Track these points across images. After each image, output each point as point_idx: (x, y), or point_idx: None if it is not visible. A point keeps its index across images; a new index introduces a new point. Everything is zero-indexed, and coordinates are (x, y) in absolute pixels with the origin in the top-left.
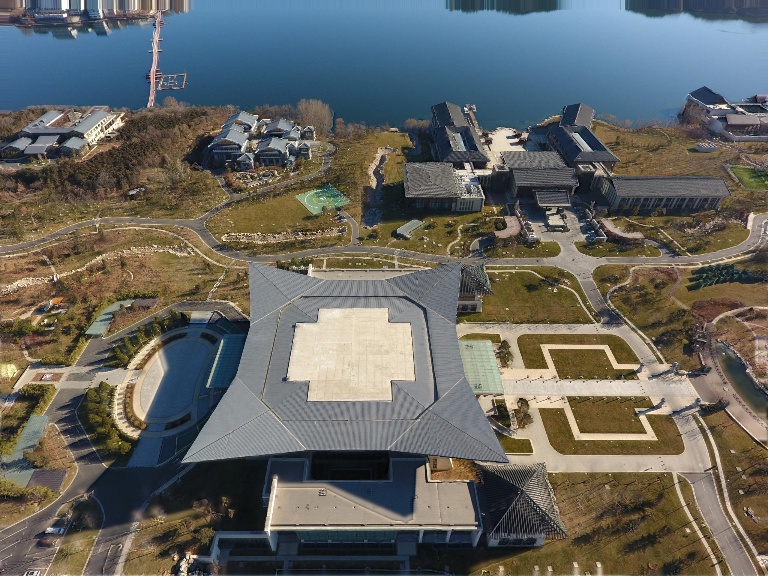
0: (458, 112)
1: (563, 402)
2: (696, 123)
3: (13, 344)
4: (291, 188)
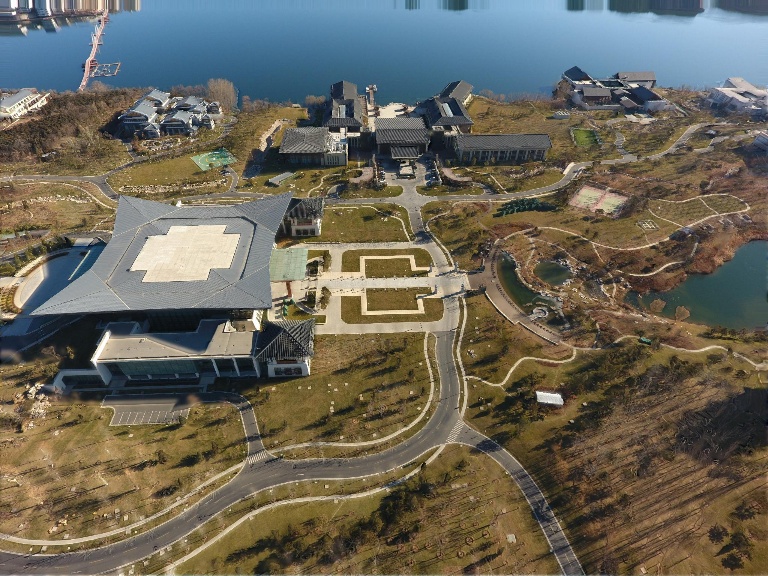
0: (353, 89)
1: (362, 292)
2: (562, 96)
3: None
4: (189, 151)
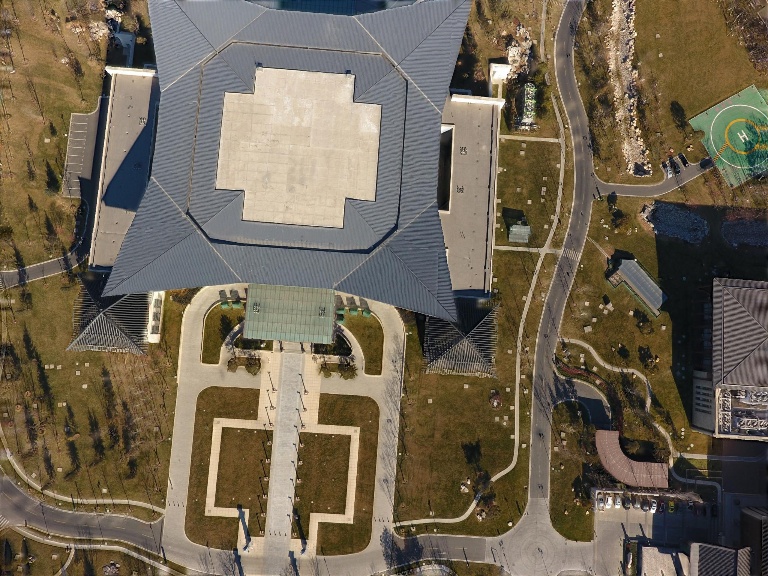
0: None
1: (265, 423)
2: None
3: None
4: None
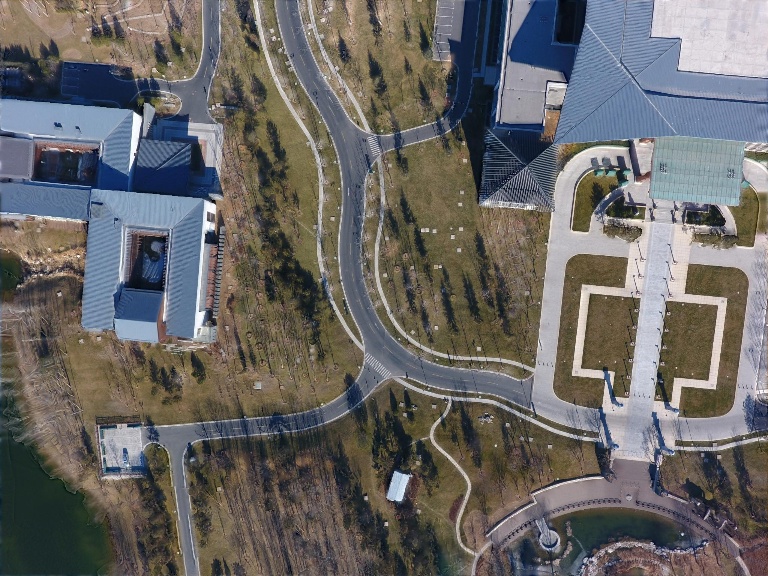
0: None
1: (633, 291)
2: None
3: None
4: None
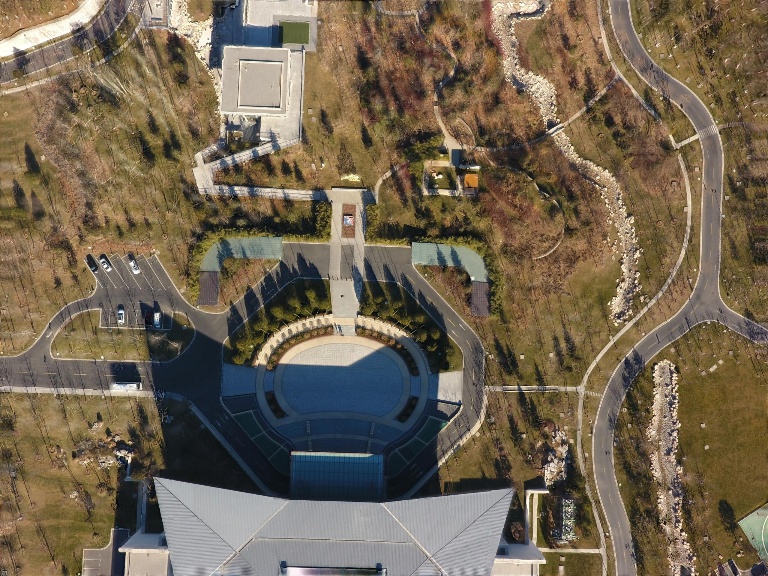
0: None
1: None
2: None
3: (397, 155)
4: None
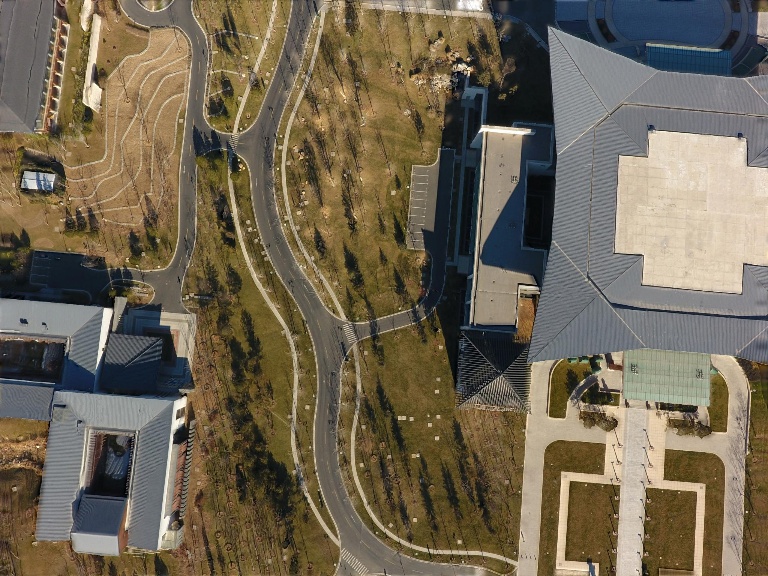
0: None
1: (612, 478)
2: None
3: None
4: None
